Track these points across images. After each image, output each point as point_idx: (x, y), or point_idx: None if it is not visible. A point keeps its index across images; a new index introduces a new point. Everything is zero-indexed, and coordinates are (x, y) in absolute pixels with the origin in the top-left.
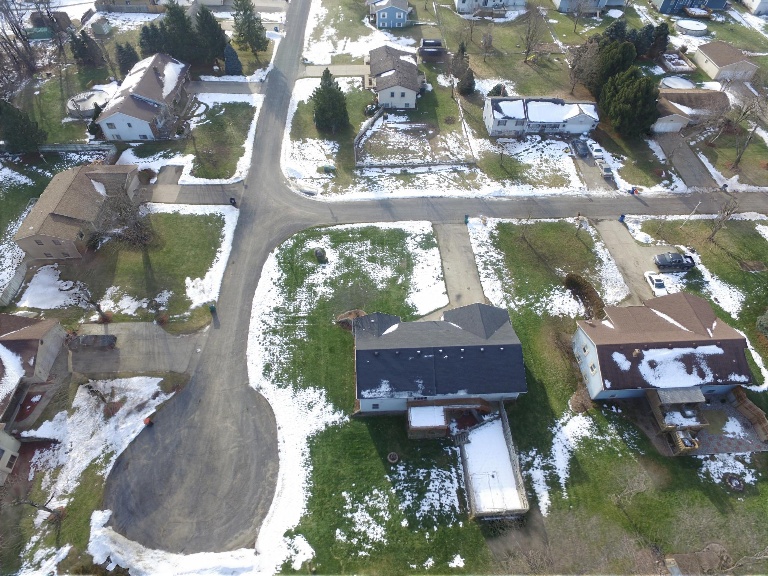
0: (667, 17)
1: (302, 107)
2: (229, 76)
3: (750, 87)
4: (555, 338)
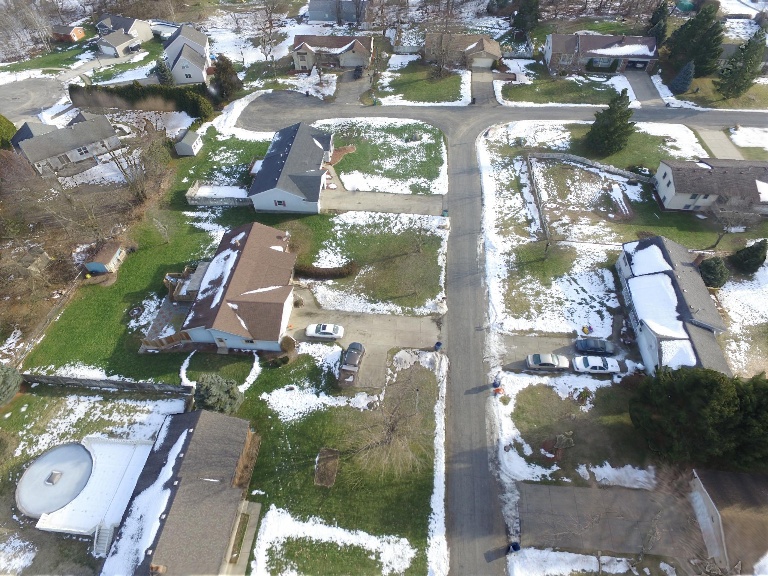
0: None
1: None
2: (667, 88)
3: None
4: (295, 244)
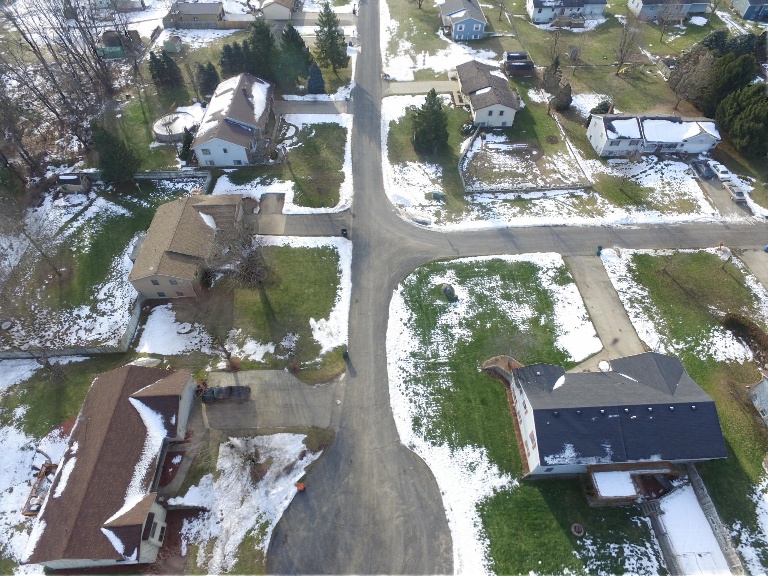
0: (754, 24)
1: (394, 127)
2: (312, 95)
3: None
4: (729, 388)
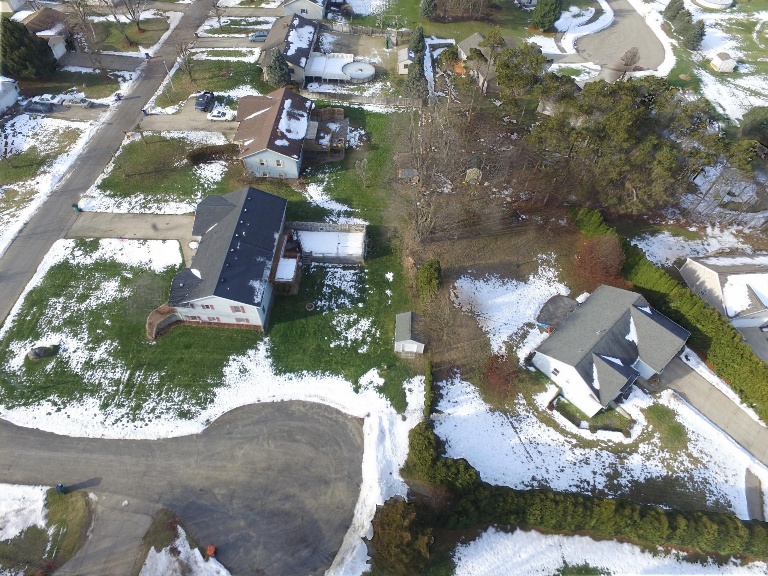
0: None
1: None
2: None
3: (42, 2)
4: (242, 183)
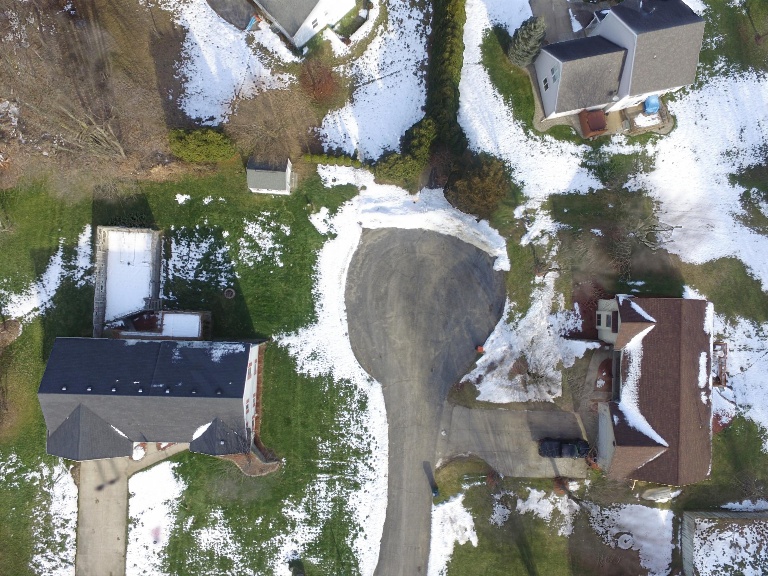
0: None
1: None
2: None
3: None
4: (5, 416)
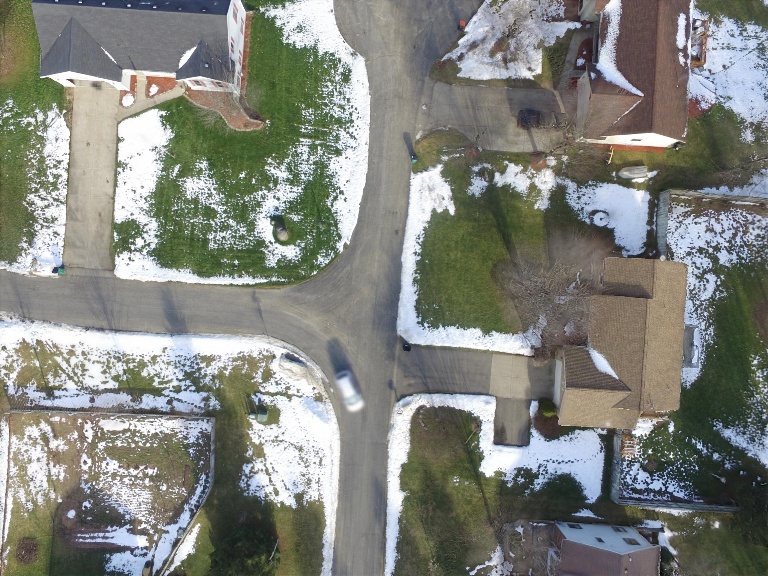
0: None
1: None
2: None
3: None
4: (3, 62)
